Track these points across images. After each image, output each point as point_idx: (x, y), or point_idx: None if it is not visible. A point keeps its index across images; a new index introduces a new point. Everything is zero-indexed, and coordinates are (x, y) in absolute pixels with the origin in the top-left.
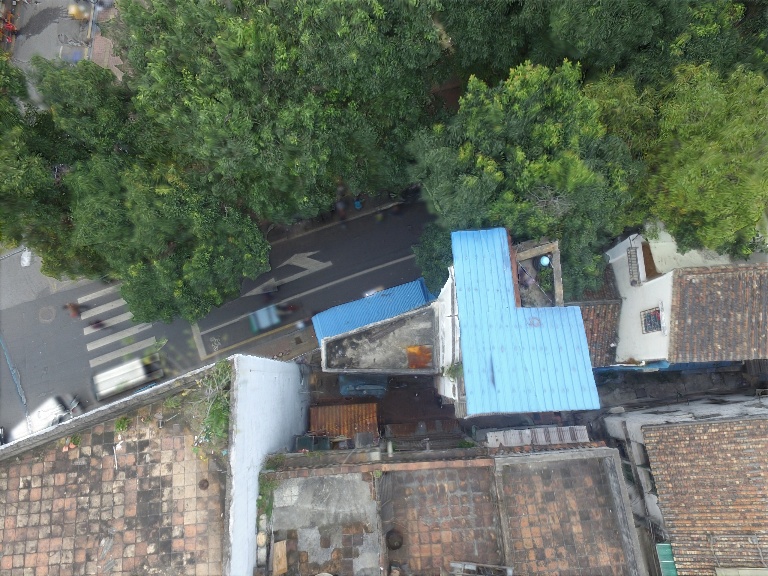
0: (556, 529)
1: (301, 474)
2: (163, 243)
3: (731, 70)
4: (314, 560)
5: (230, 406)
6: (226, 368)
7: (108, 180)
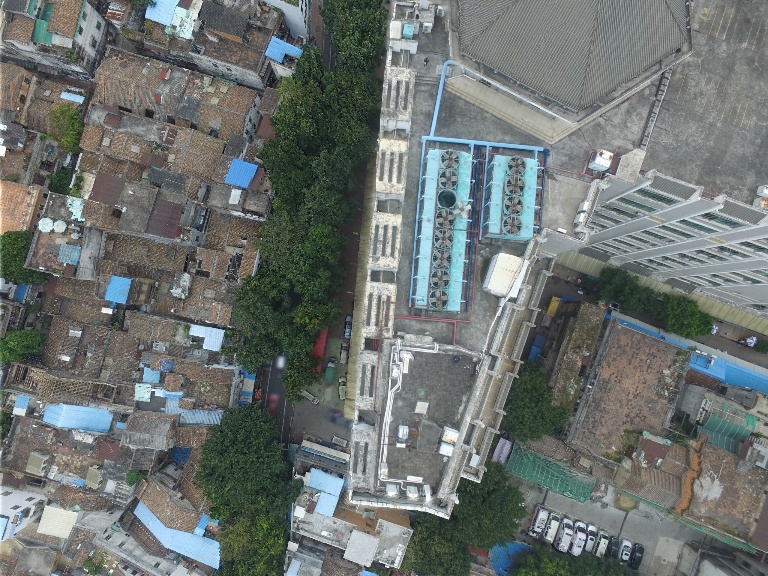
0: (249, 58)
1: None
2: (333, 7)
3: None
4: (263, 15)
5: (291, 4)
6: (297, 5)
7: (350, 0)
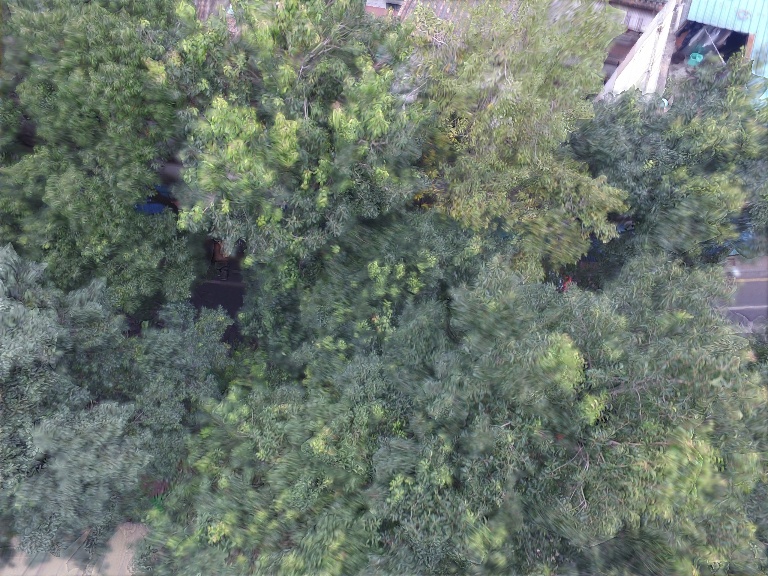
0: None
1: None
2: None
3: (409, 211)
4: None
5: None
6: None
7: None
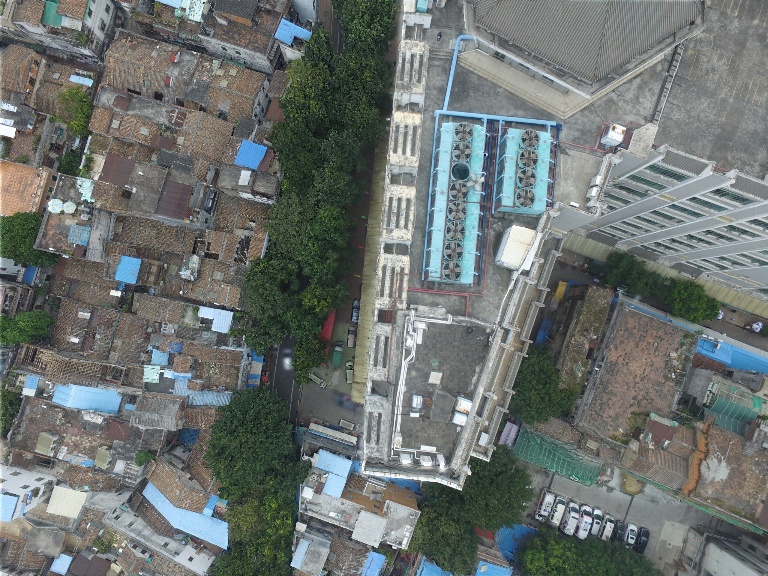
0: (258, 41)
1: (287, 0)
2: None
3: None
4: None
5: None
6: None
7: None
